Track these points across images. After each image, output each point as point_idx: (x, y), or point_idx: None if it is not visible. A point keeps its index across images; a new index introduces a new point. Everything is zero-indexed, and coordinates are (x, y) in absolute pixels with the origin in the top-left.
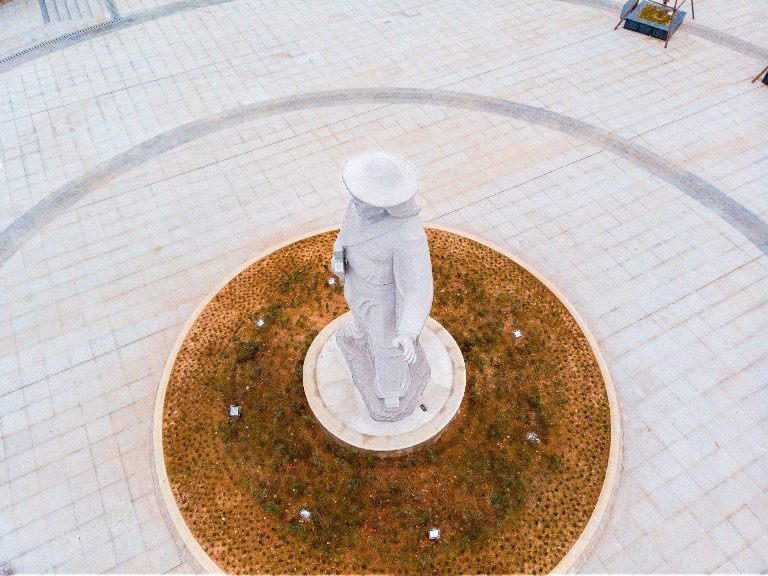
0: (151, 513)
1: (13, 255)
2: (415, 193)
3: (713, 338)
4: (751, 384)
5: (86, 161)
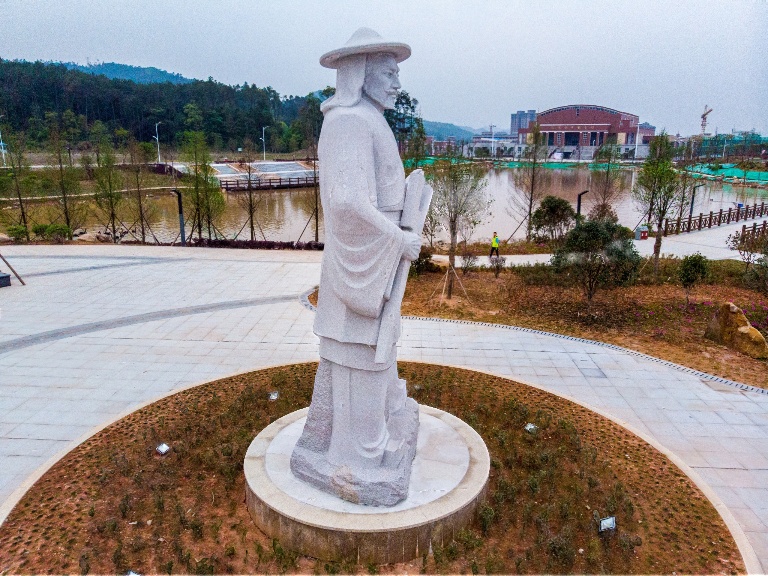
0: (736, 512)
1: None
2: None
3: (4, 405)
4: (54, 380)
5: None
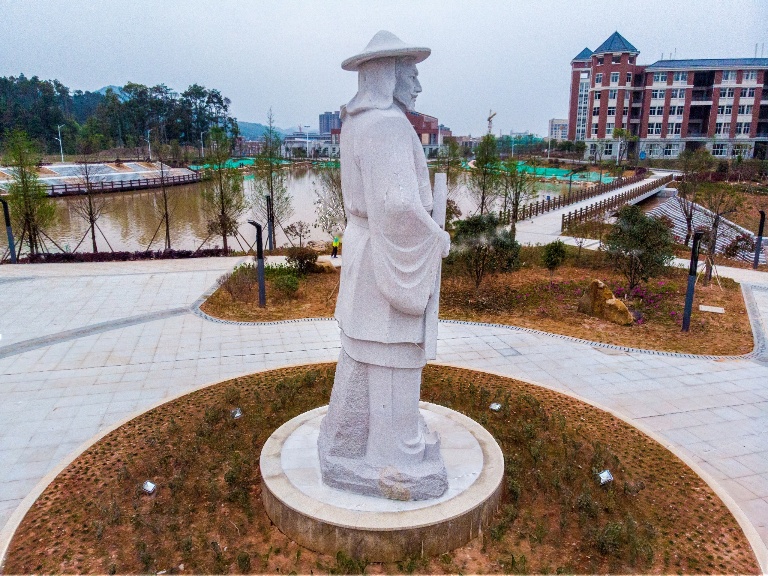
0: None
1: None
2: None
3: None
4: None
5: None
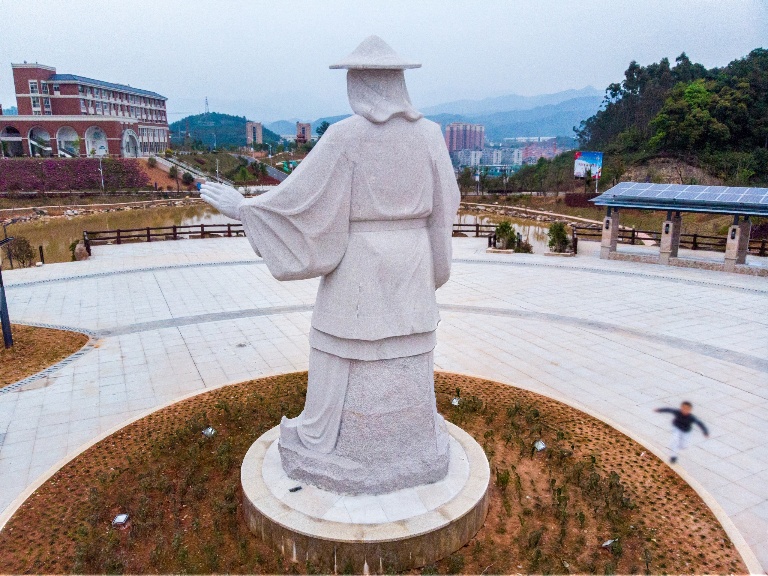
0: None
1: (516, 318)
2: (351, 65)
3: None
4: None
5: (652, 328)
